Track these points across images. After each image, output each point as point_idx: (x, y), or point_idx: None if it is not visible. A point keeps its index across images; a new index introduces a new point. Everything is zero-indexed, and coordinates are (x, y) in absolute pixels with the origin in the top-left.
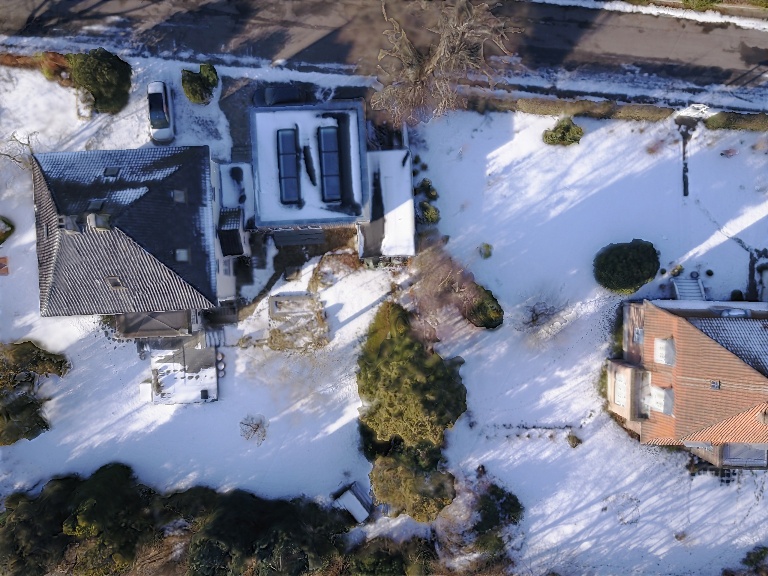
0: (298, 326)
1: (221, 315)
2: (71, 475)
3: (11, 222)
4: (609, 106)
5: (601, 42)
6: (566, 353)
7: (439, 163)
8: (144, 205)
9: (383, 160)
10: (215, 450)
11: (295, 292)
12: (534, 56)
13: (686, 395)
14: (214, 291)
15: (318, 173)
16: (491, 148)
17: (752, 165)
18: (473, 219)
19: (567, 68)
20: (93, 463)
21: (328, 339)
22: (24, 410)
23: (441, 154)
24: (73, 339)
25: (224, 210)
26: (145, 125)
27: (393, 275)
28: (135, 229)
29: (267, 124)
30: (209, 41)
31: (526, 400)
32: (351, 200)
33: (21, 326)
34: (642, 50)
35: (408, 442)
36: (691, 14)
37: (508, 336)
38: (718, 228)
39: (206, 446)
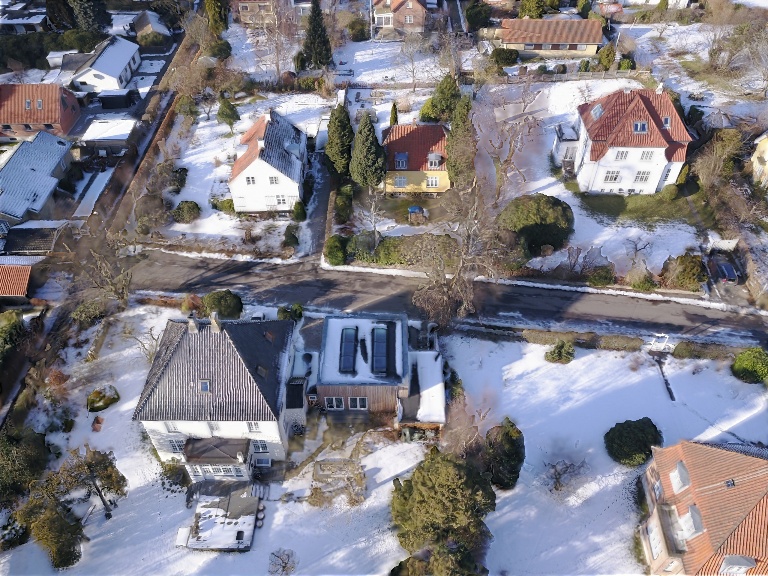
0: (338, 487)
1: (269, 478)
2: None
3: (119, 394)
4: (592, 335)
5: (579, 308)
6: (595, 519)
7: (464, 371)
8: (246, 328)
9: (420, 357)
10: None
11: (339, 459)
12: (531, 313)
13: (709, 503)
14: (278, 409)
15: (370, 355)
16: (505, 363)
17: (722, 382)
18: (494, 409)
19: (557, 321)
20: None
21: (365, 496)
22: (69, 528)
23: (465, 365)
24: (132, 486)
25: (293, 377)
26: None
27: (427, 448)
28: (236, 337)
29: (336, 325)
30: (300, 299)
31: (563, 563)
32: (394, 373)
33: None
34: (610, 313)
35: (440, 515)
36: (641, 295)
37: (536, 502)
38: (710, 424)
39: None
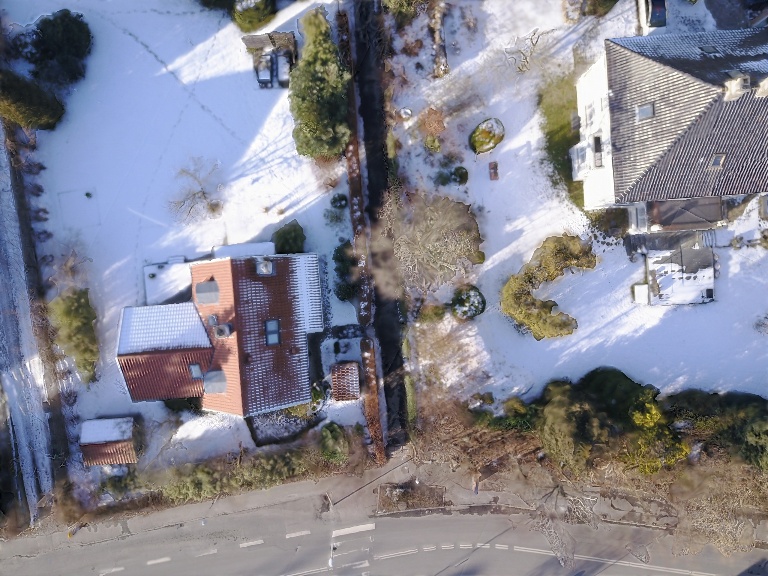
0: None
1: None
2: (560, 379)
3: None
4: None
5: None
6: None
7: None
8: None
9: None
10: (708, 352)
11: None
12: None
13: None
14: None
15: None
16: None
17: None
18: None
19: None
20: (581, 367)
21: None
22: None
23: None
24: None
25: None
26: (632, 26)
27: None
28: None
29: None
30: None
31: None
32: None
33: (512, 230)
34: None
35: None
36: None
37: None
38: None
39: (699, 348)
